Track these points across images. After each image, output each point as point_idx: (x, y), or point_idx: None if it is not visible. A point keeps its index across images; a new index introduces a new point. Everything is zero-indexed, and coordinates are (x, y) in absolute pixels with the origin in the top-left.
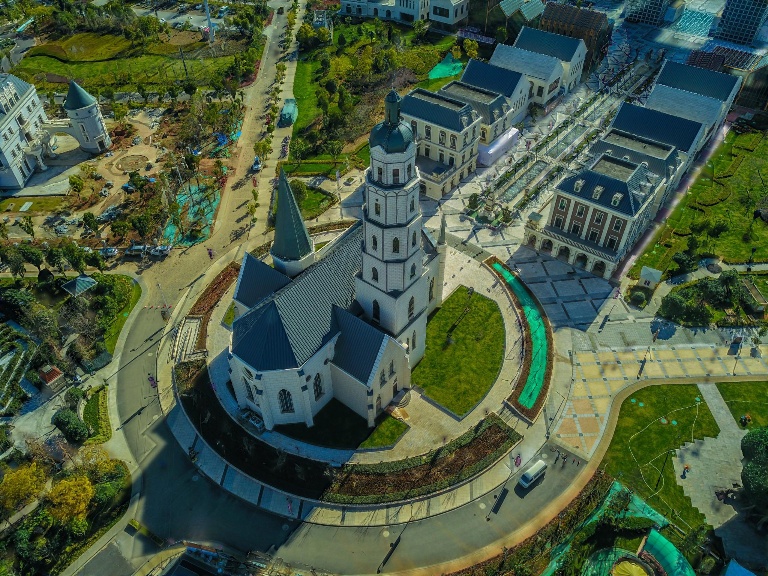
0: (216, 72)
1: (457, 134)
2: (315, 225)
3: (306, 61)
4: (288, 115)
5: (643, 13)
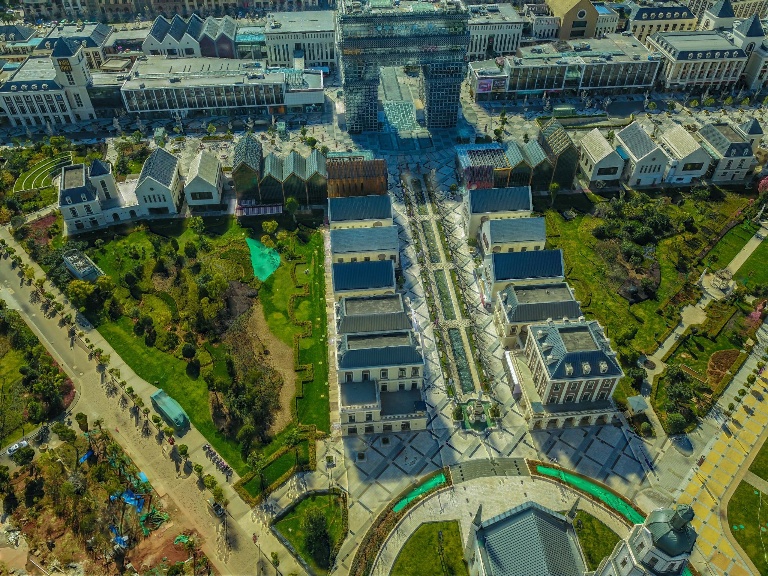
0: (29, 410)
1: (421, 365)
2: (358, 541)
3: (107, 324)
4: (181, 418)
5: (362, 124)
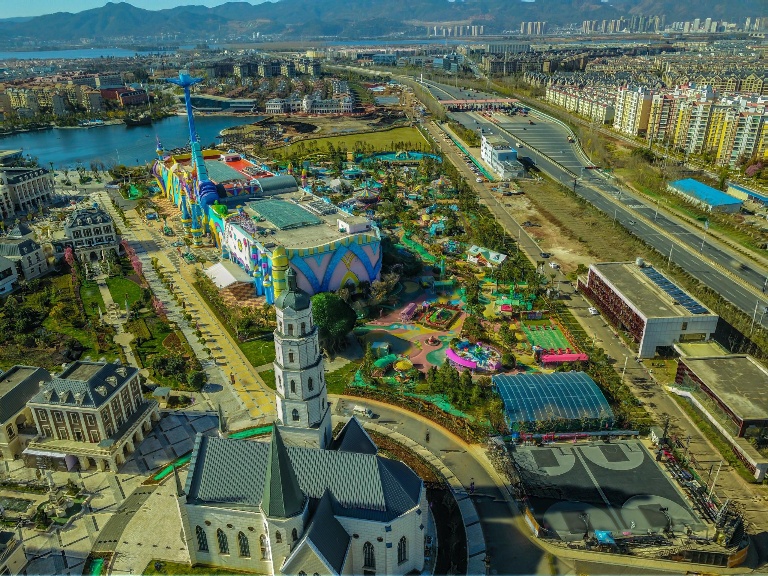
0: None
1: None
2: None
3: None
4: None
5: None
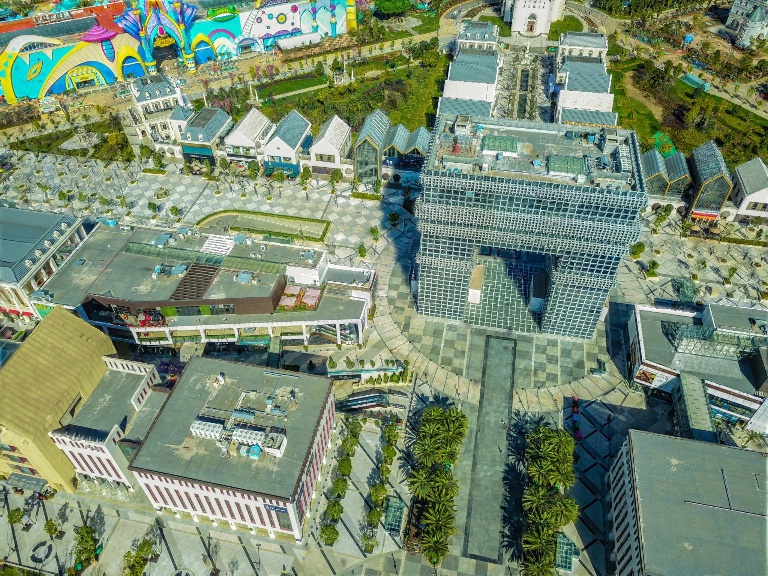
0: None
1: None
2: None
3: None
4: None
5: None
